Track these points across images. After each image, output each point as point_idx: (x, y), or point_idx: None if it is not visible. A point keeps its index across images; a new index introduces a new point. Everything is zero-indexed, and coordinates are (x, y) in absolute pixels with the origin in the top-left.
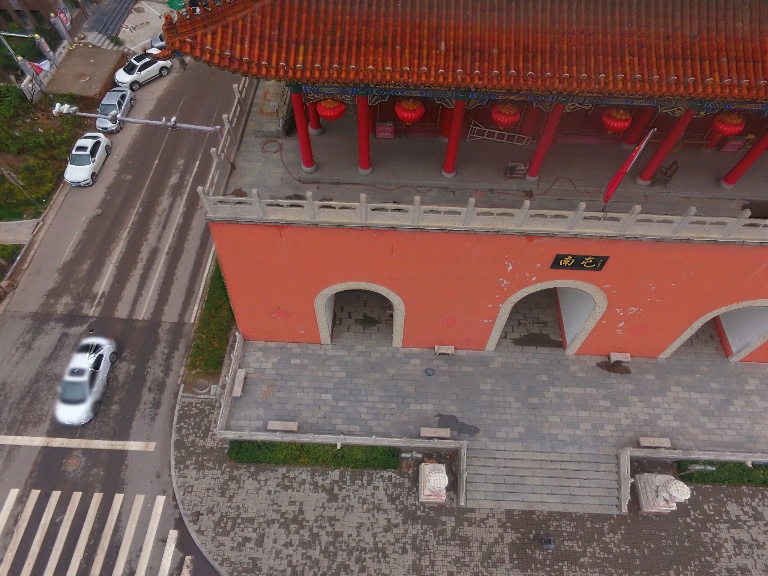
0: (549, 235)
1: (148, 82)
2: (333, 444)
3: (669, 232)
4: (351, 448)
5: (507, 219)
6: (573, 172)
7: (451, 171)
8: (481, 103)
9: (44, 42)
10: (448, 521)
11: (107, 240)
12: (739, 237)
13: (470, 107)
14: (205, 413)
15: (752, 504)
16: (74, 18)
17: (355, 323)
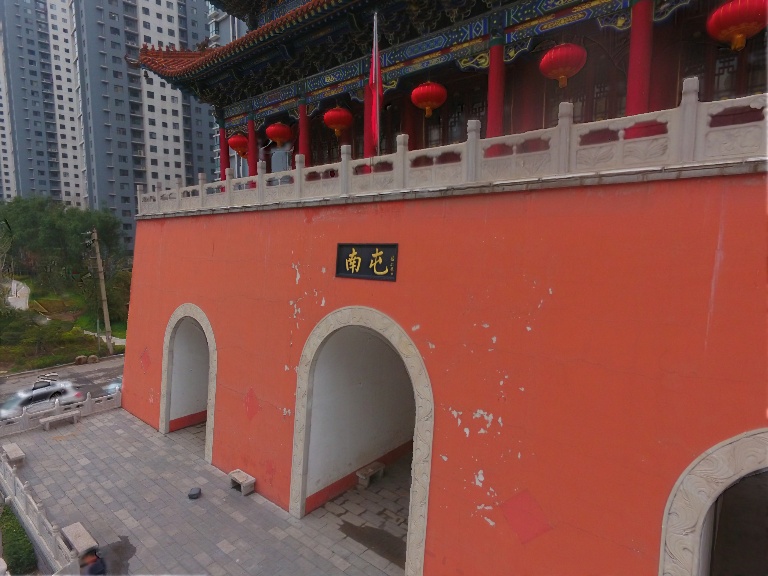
0: (321, 203)
1: None
2: None
3: (464, 181)
4: (11, 520)
5: (289, 188)
6: None
7: None
8: (316, 108)
9: None
10: None
11: None
12: (589, 171)
13: (310, 114)
14: None
15: None
16: None
17: None
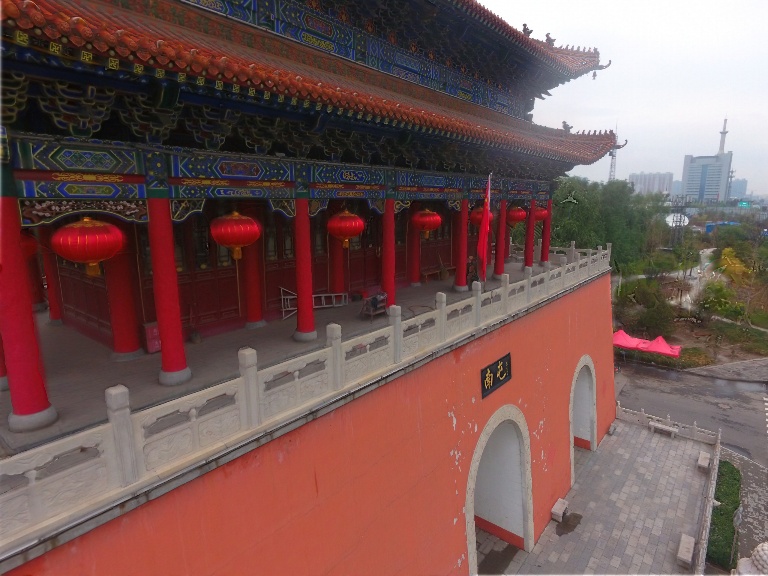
0: (470, 339)
1: None
2: None
3: (526, 303)
4: None
5: (430, 332)
6: (411, 303)
7: (312, 328)
8: (323, 207)
9: None
10: None
11: None
12: (553, 293)
13: (312, 214)
14: None
15: (762, 537)
16: None
17: None
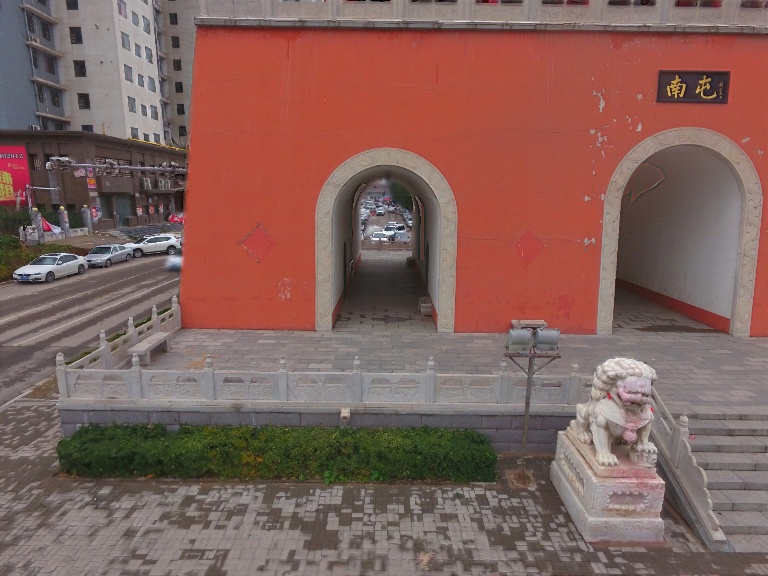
0: (641, 28)
1: (152, 254)
2: (331, 427)
3: None
4: (374, 433)
5: (581, 9)
6: None
7: None
8: None
9: (66, 214)
10: None
11: (26, 305)
12: None
13: None
14: (49, 416)
15: None
16: (103, 220)
17: (372, 320)
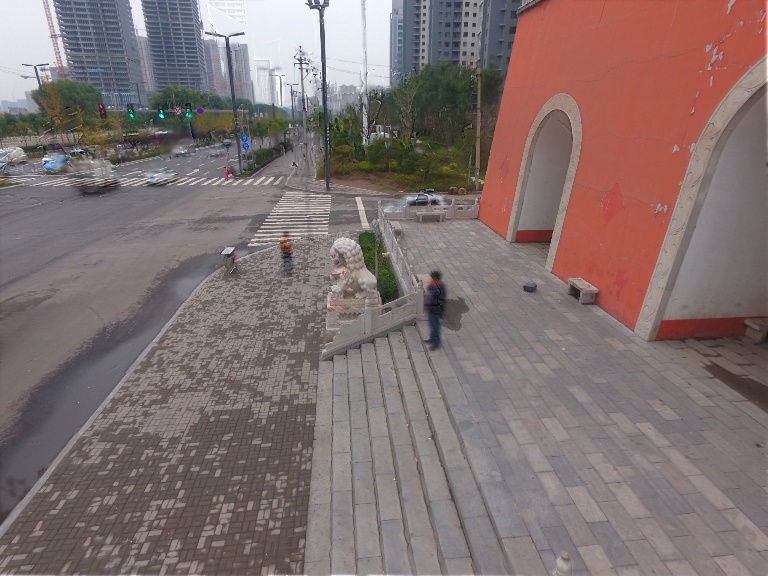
0: None
1: None
2: None
3: None
4: (387, 269)
5: None
6: None
7: None
8: None
9: None
10: (298, 346)
11: None
12: None
13: None
14: None
15: None
16: None
17: None
